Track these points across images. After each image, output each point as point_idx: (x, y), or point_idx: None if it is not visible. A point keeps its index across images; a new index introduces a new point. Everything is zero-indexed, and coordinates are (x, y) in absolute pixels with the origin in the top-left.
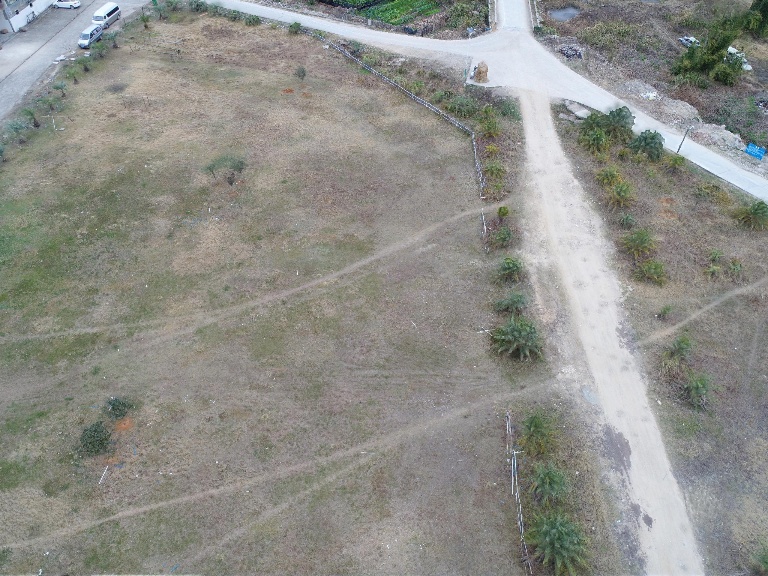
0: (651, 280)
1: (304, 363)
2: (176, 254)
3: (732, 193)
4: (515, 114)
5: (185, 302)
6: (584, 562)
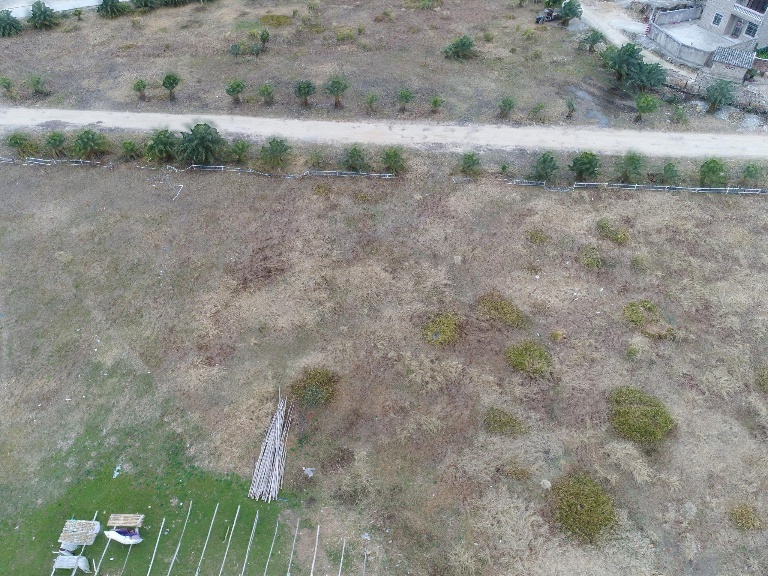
0: None
1: None
2: None
3: None
4: None
5: None
6: (105, 136)
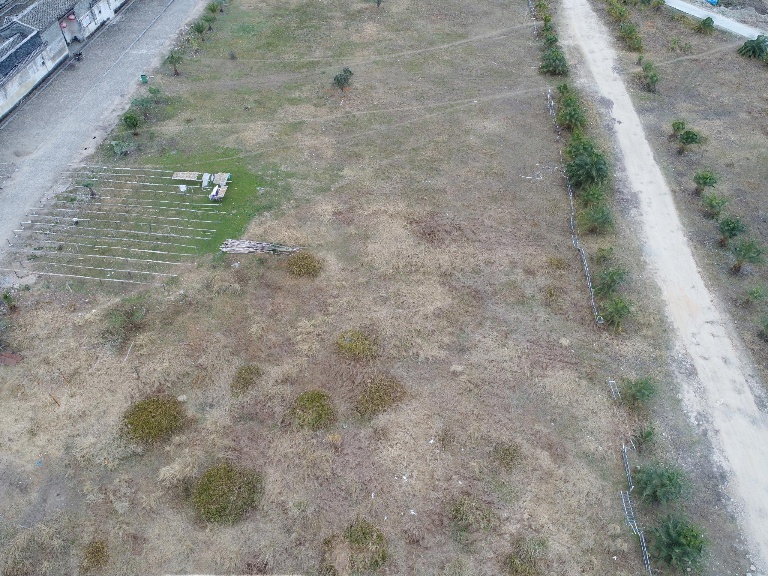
0: (635, 50)
1: (436, 74)
2: (352, 35)
3: (694, 20)
4: None
5: (363, 52)
6: None
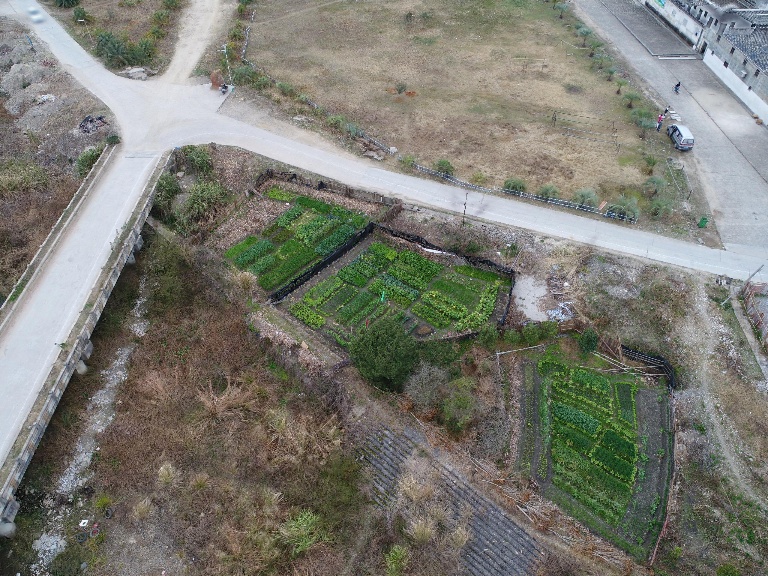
0: None
1: None
2: (423, 4)
3: None
4: None
5: None
6: None
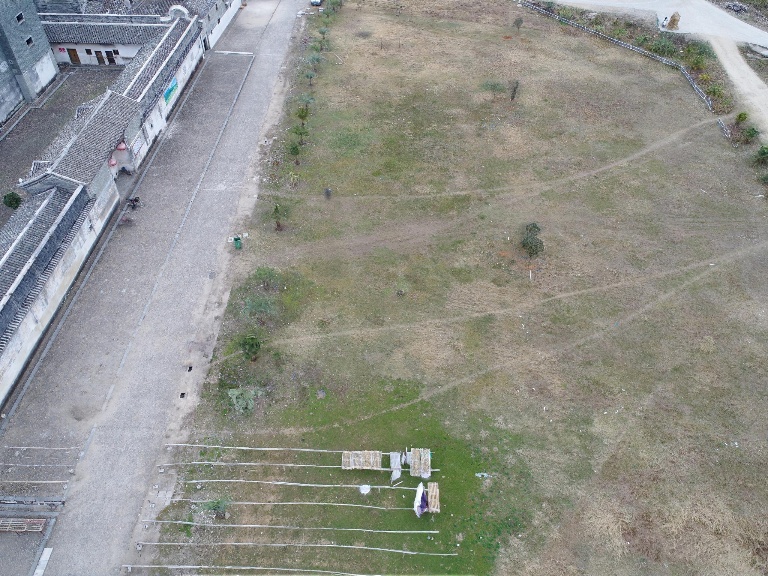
0: None
1: (635, 214)
2: (492, 147)
3: None
4: (710, 53)
5: (520, 177)
6: None
